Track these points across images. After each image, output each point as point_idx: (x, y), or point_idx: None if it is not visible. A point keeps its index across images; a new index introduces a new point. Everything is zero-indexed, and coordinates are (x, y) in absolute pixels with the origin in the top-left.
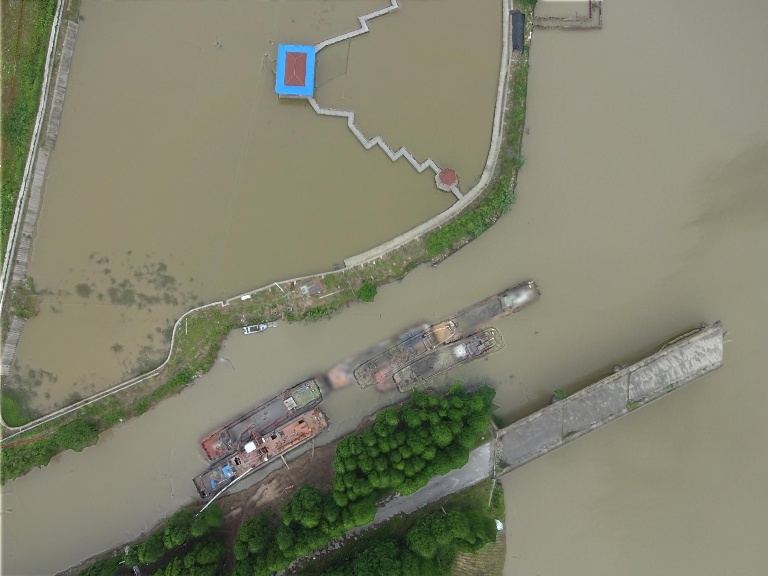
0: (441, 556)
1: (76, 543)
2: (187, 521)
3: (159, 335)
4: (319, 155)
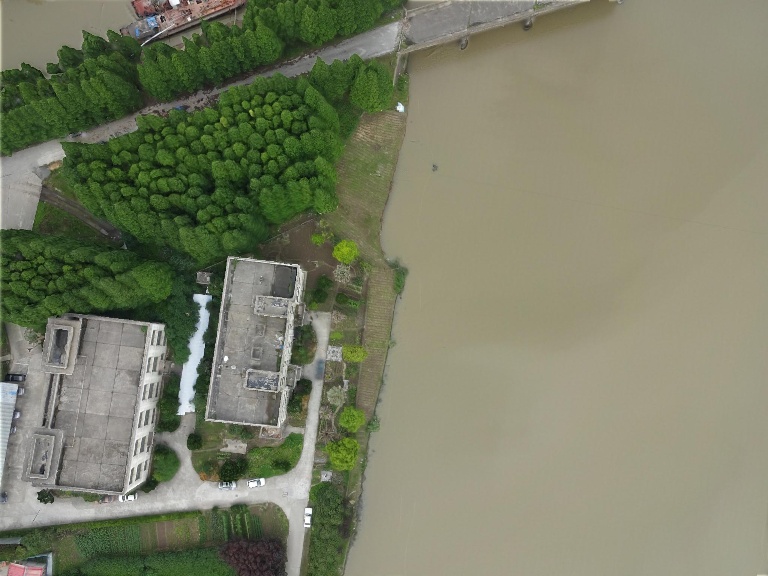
0: (342, 123)
1: None
2: (106, 41)
3: None
4: None
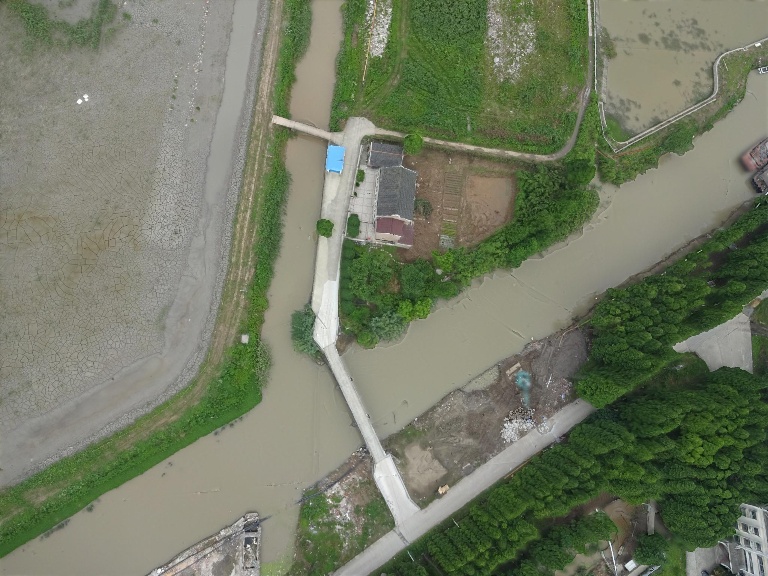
0: None
1: (650, 245)
2: None
3: (703, 73)
4: None
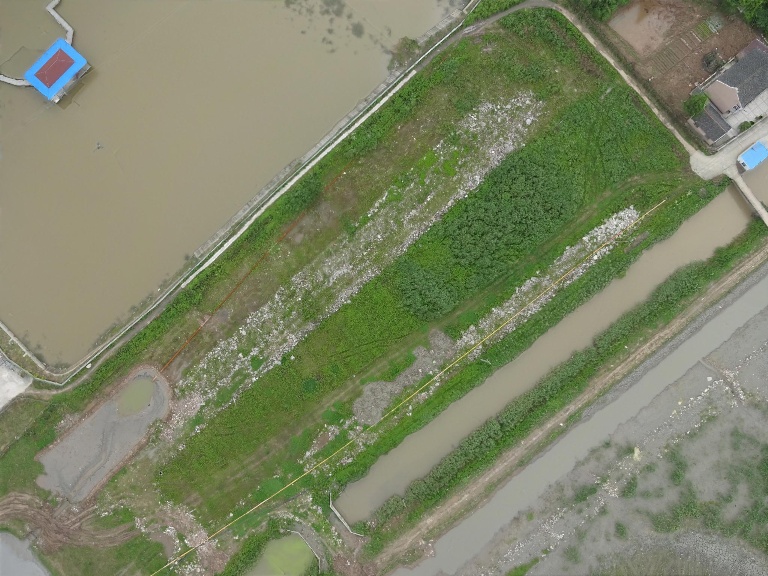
0: None
1: None
2: None
3: None
4: None
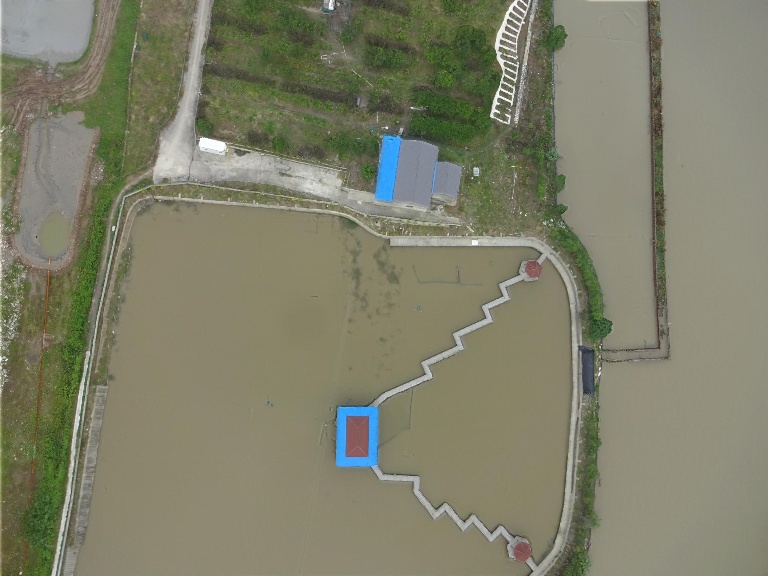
0: None
1: None
2: None
3: None
4: (383, 528)
